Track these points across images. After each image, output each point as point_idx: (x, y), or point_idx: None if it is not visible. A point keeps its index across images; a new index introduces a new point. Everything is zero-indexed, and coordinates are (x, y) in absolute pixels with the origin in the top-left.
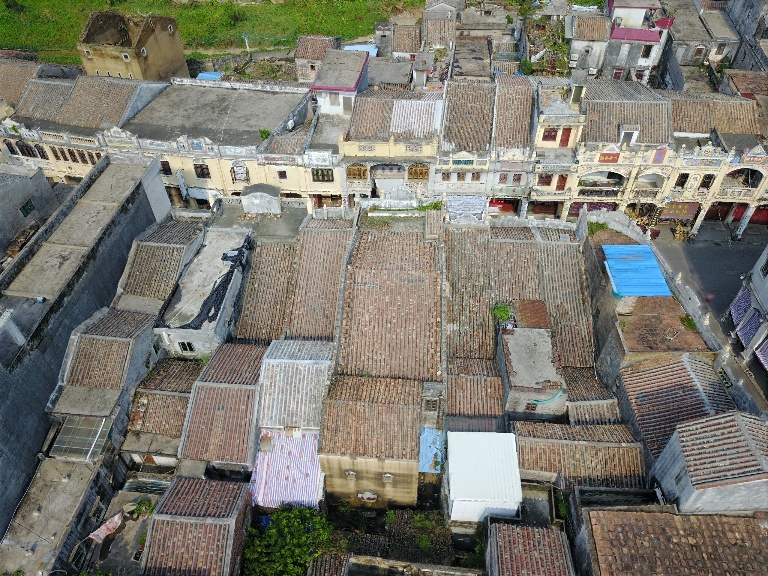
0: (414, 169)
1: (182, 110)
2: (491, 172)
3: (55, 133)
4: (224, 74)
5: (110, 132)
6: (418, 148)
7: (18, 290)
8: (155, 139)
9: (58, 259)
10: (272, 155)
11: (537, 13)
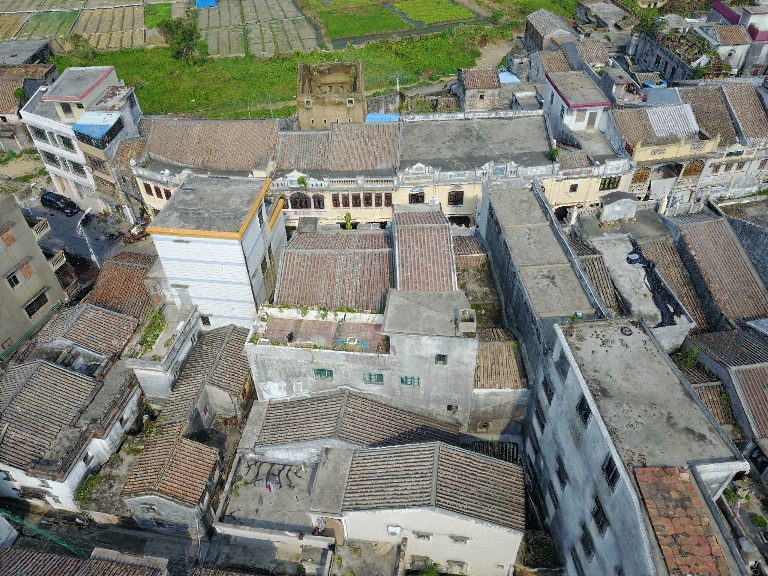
0: (690, 166)
1: (440, 143)
2: (755, 160)
3: (349, 178)
4: (404, 112)
5: (412, 169)
6: (701, 146)
7: (543, 311)
8: (457, 170)
9: (545, 279)
10: (572, 170)
11: (667, 28)
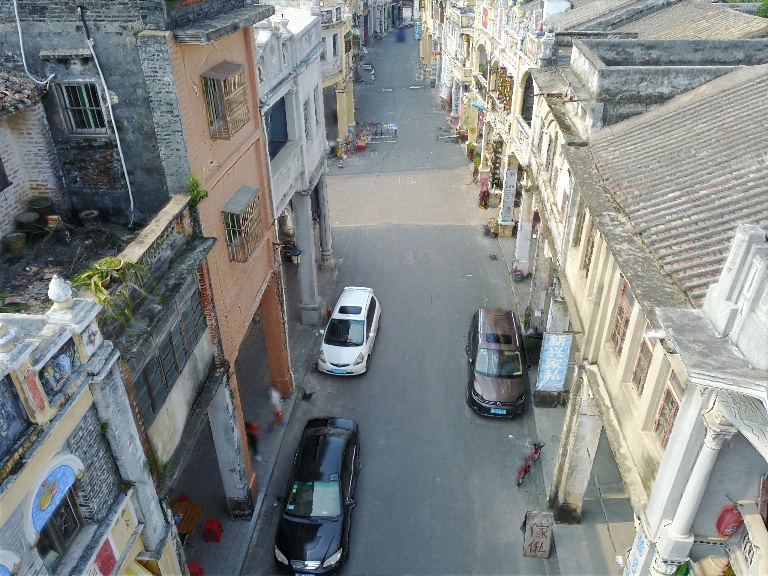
0: None
1: None
2: None
3: None
4: None
5: None
6: None
7: None
8: None
9: None
10: None
11: None
